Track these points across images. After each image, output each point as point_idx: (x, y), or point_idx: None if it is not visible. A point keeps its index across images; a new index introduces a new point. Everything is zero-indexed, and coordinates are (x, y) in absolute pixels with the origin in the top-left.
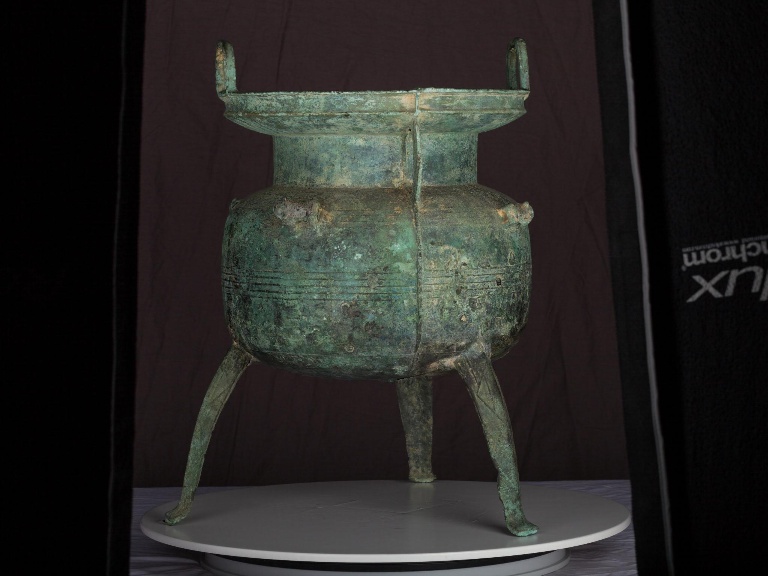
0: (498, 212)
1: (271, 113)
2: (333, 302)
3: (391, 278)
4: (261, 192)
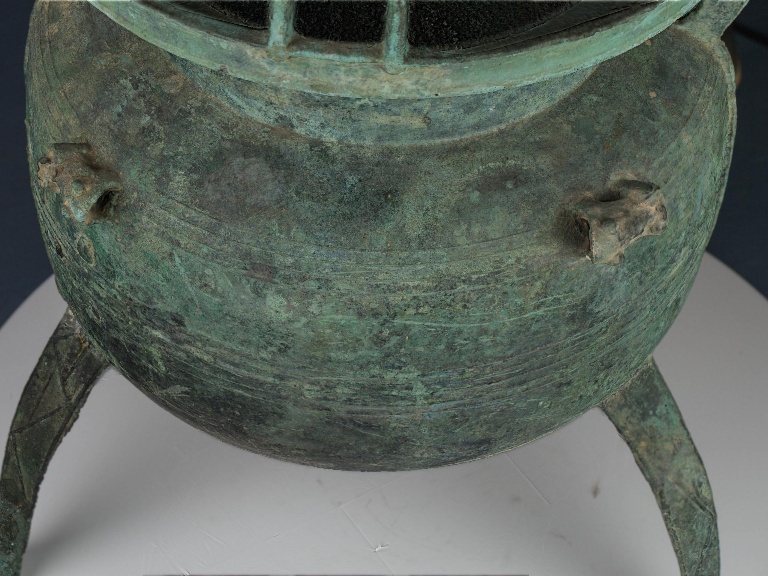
0: None
1: None
2: None
3: None
4: None
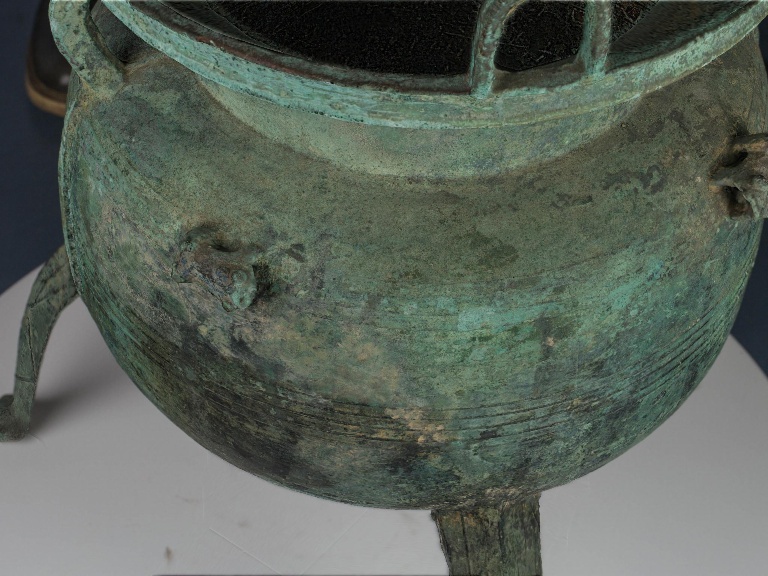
0: None
1: (731, 45)
2: None
3: None
4: (518, 210)
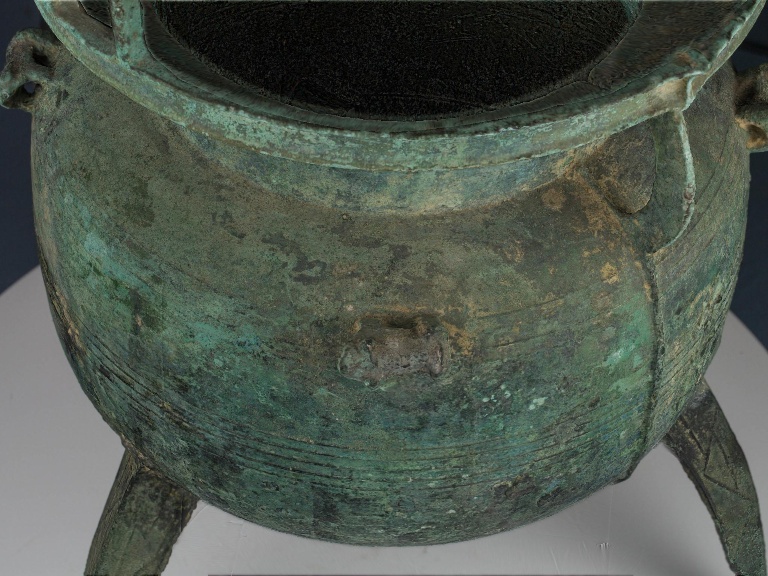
0: (740, 124)
1: (305, 159)
2: (475, 486)
3: (602, 412)
4: (187, 194)
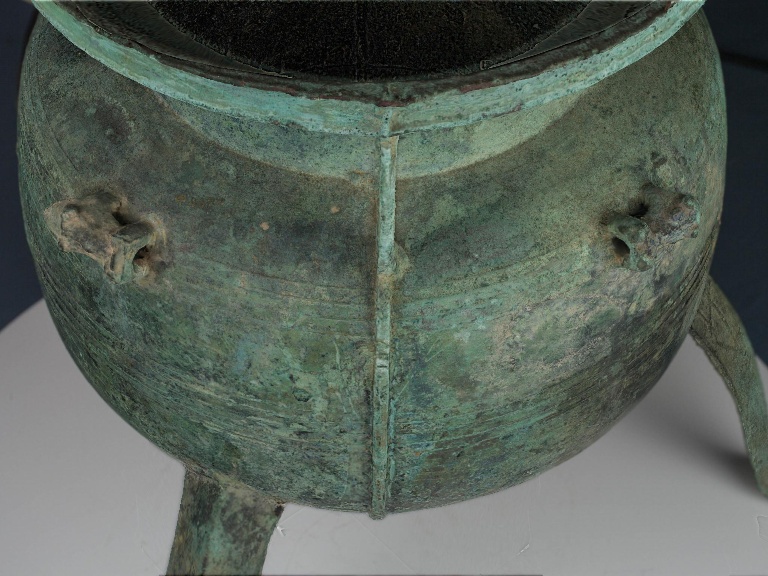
0: None
1: None
2: None
3: None
4: None
